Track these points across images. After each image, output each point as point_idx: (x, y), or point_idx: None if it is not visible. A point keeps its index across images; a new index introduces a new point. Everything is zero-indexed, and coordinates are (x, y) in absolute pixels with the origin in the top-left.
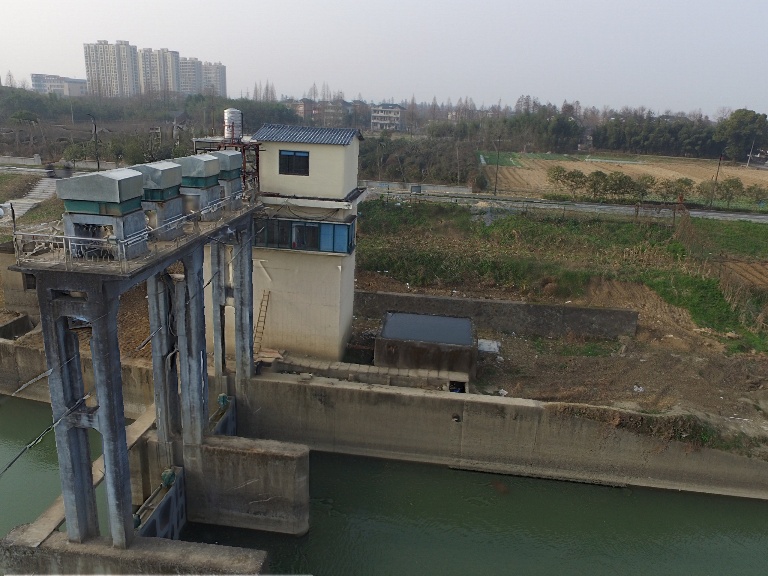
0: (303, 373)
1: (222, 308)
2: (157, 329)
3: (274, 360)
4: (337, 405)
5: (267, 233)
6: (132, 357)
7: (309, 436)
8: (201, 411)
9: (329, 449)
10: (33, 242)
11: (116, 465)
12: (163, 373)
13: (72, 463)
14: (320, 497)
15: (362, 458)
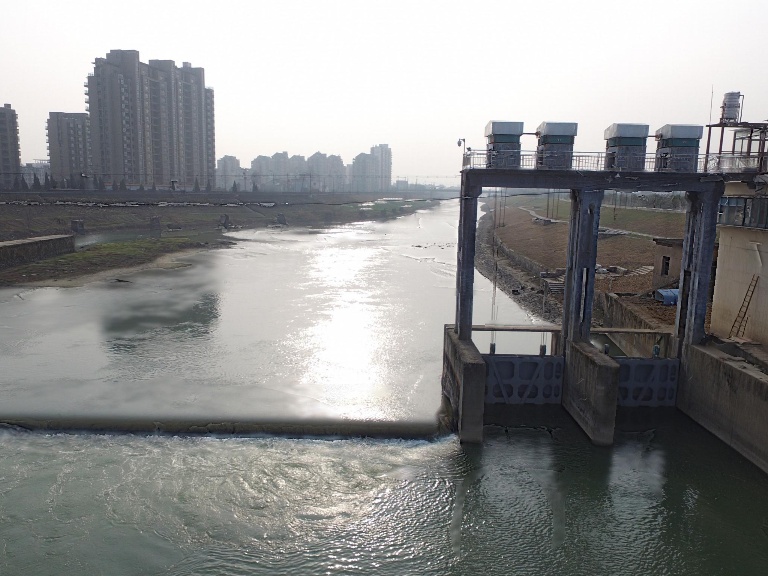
0: (739, 357)
1: (687, 273)
2: (466, 197)
3: (731, 342)
4: (738, 391)
5: (759, 213)
6: (653, 317)
7: (717, 419)
8: (577, 315)
9: (728, 440)
10: (682, 240)
11: (461, 284)
12: (569, 281)
13: (458, 282)
14: (653, 446)
15: (749, 463)
